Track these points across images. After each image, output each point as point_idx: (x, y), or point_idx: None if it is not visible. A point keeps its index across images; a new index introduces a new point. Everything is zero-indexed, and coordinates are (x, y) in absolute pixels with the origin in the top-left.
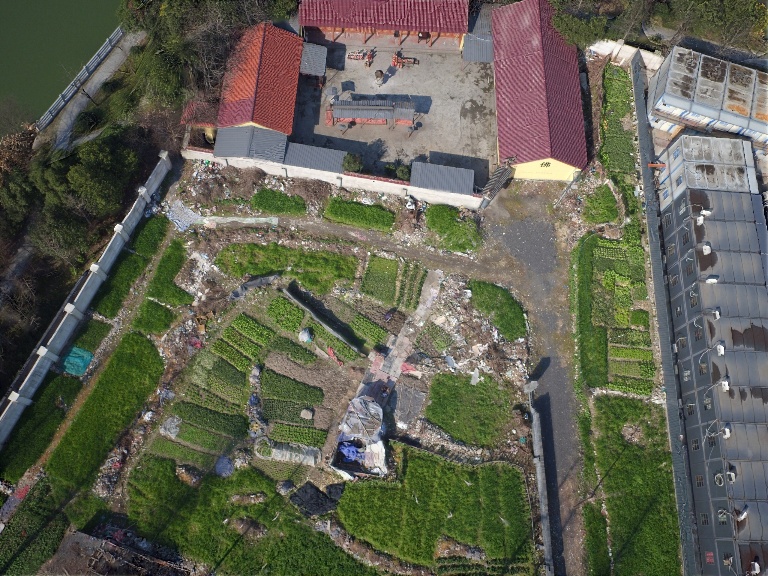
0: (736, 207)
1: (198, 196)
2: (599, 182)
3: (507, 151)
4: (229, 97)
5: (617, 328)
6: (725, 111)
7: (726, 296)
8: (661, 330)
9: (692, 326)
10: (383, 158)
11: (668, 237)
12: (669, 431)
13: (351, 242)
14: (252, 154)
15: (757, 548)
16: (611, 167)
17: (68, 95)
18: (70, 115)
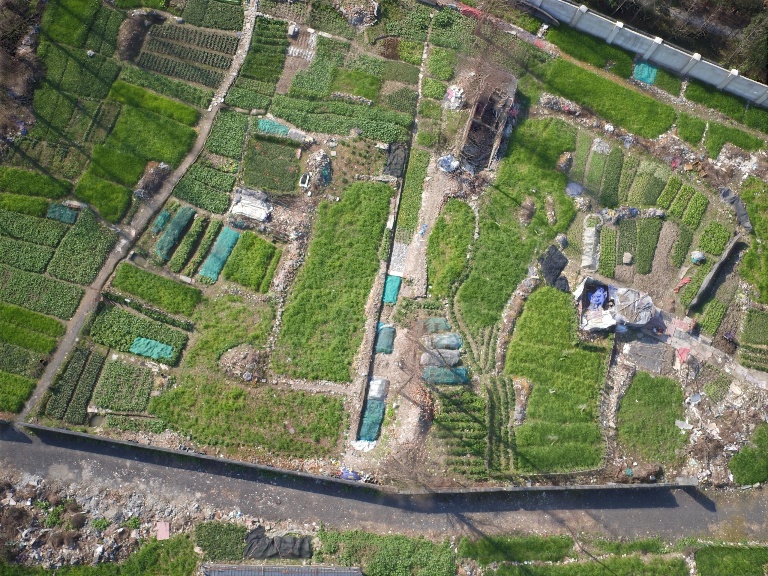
0: None
1: None
2: None
3: None
4: None
5: None
6: None
7: None
8: None
9: None
10: None
11: None
12: None
13: None
14: None
15: None
16: None
17: None
18: None
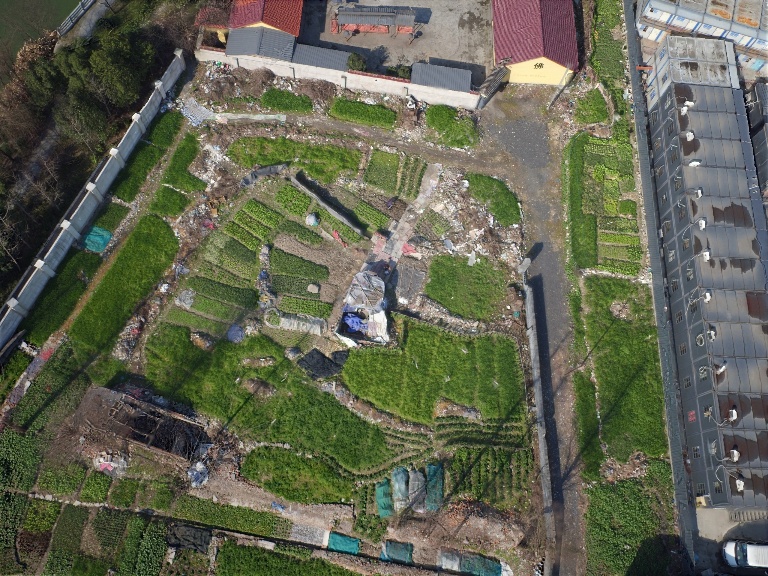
0: (718, 100)
1: (211, 93)
2: (590, 87)
3: (502, 53)
4: (240, 2)
5: (606, 216)
6: (708, 15)
7: (708, 178)
8: (648, 218)
9: (676, 208)
10: (385, 63)
11: (655, 133)
12: (655, 308)
13: (355, 137)
14: (262, 52)
15: (735, 398)
16: (601, 73)
17: (87, 4)
18: (89, 22)
